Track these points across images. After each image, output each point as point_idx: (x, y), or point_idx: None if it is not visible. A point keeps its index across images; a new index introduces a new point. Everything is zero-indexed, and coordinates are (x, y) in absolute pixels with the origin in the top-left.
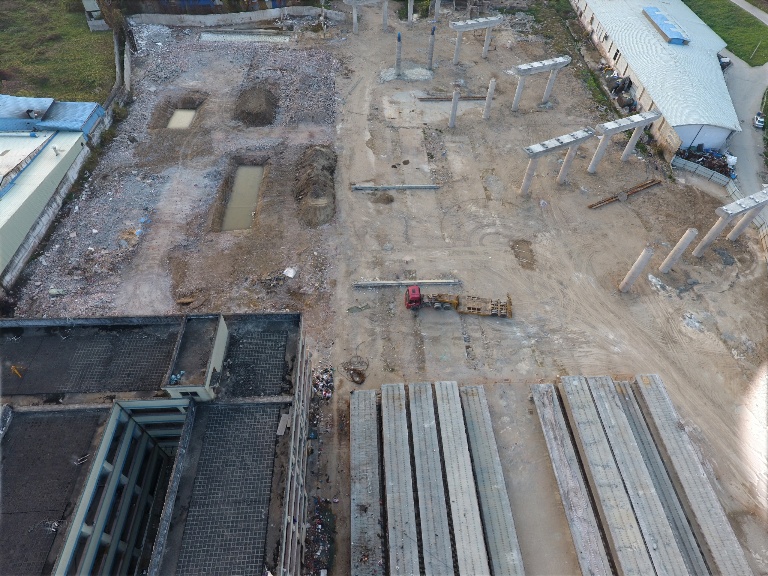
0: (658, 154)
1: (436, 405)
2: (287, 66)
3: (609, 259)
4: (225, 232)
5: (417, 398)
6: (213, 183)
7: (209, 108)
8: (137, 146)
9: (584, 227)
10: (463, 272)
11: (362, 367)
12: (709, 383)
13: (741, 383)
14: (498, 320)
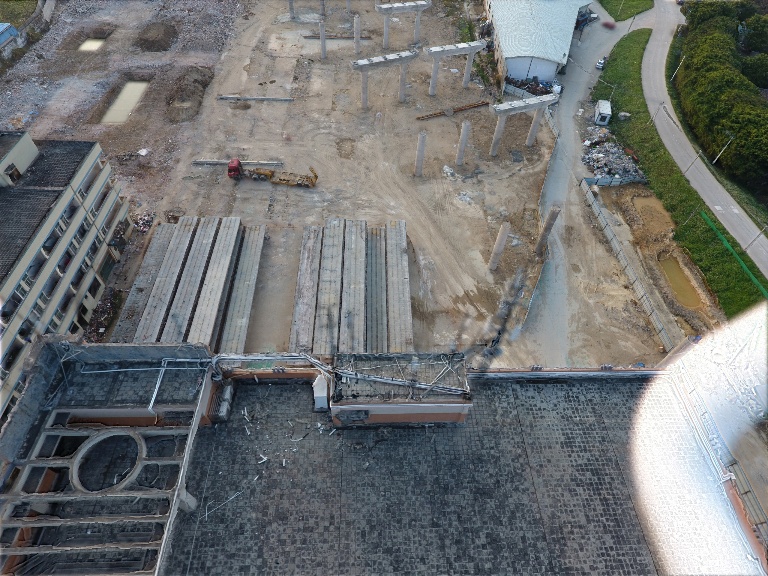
0: (496, 84)
1: (218, 231)
2: (196, 8)
3: None
4: (99, 124)
5: (204, 226)
6: (100, 90)
7: (115, 37)
8: (43, 62)
9: (406, 132)
10: (288, 158)
11: (179, 214)
12: (457, 236)
13: (483, 237)
14: (303, 189)
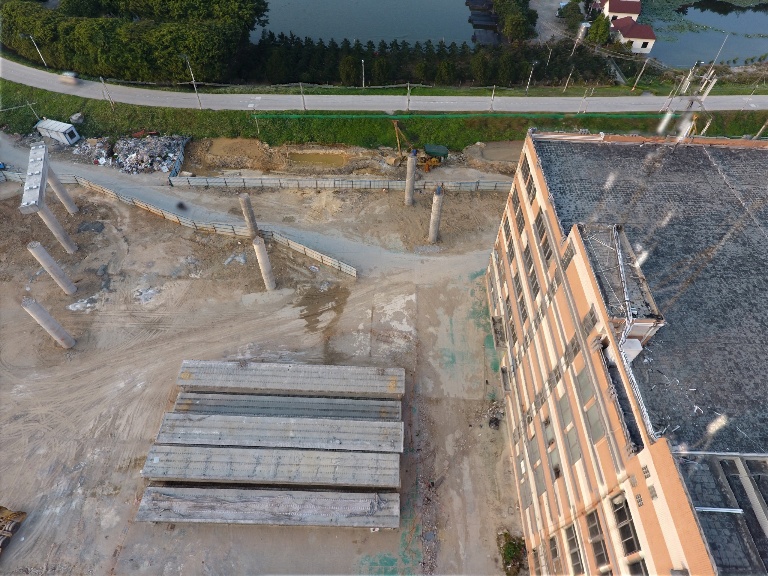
0: None
1: None
2: None
3: (19, 341)
4: None
5: None
6: None
7: None
8: None
9: None
10: None
11: None
12: (213, 313)
13: (223, 287)
14: (19, 537)
